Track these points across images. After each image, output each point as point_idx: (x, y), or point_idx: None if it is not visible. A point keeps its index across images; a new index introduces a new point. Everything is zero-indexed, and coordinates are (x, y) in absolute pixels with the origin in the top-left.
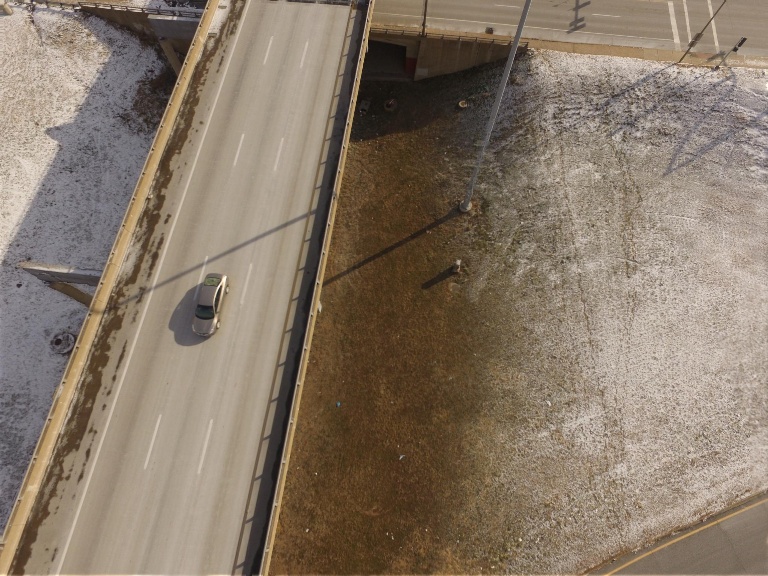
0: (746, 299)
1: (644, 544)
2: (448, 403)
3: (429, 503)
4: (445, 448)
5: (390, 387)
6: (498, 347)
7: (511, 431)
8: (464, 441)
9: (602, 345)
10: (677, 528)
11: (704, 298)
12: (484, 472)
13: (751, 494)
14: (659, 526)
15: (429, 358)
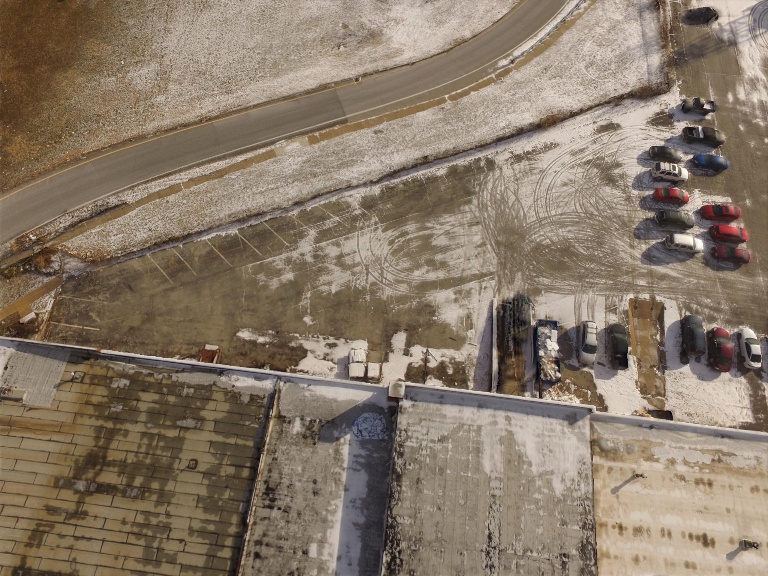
0: (288, 6)
1: (156, 133)
2: (50, 62)
3: (15, 113)
4: (38, 85)
5: (13, 55)
6: (98, 32)
7: (89, 77)
8: (53, 82)
9: (172, 30)
10: (182, 124)
11: (256, 4)
12: (61, 98)
13: (241, 107)
14: (170, 123)
15: (46, 39)
